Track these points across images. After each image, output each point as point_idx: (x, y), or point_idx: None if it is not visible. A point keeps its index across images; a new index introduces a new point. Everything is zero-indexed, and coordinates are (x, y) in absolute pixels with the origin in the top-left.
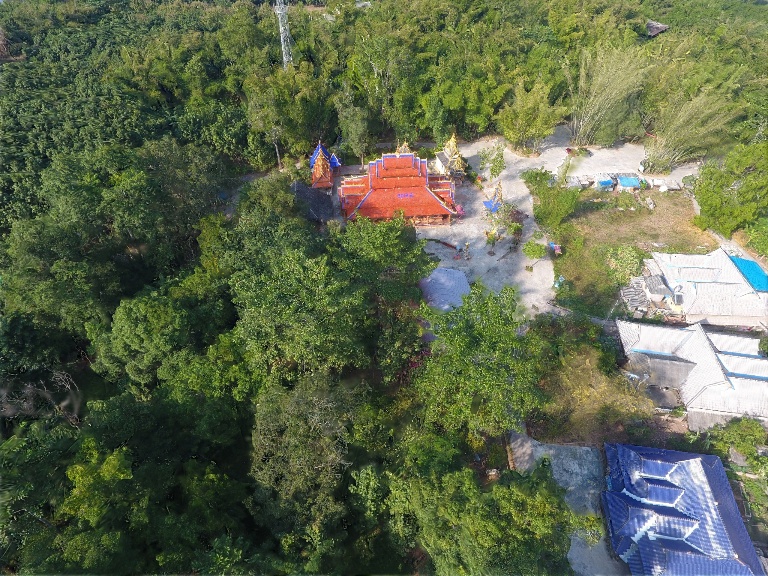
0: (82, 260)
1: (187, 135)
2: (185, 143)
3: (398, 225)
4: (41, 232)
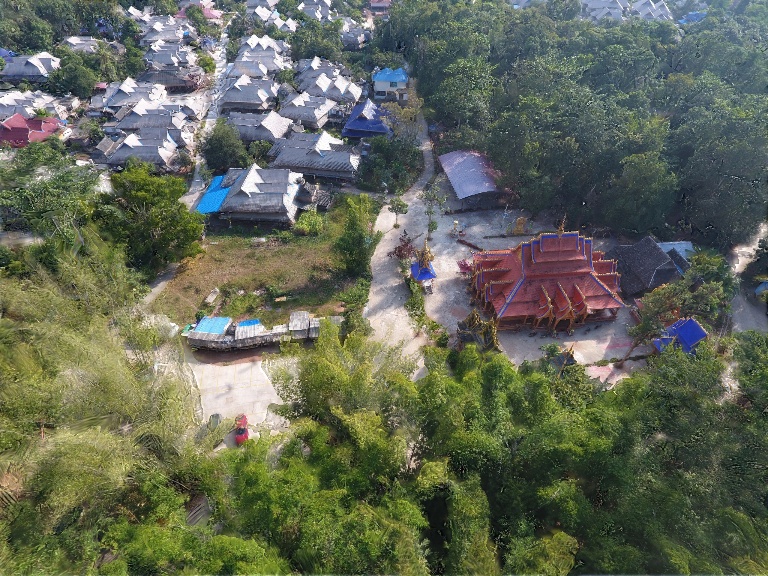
0: None
1: None
2: None
3: None
4: None
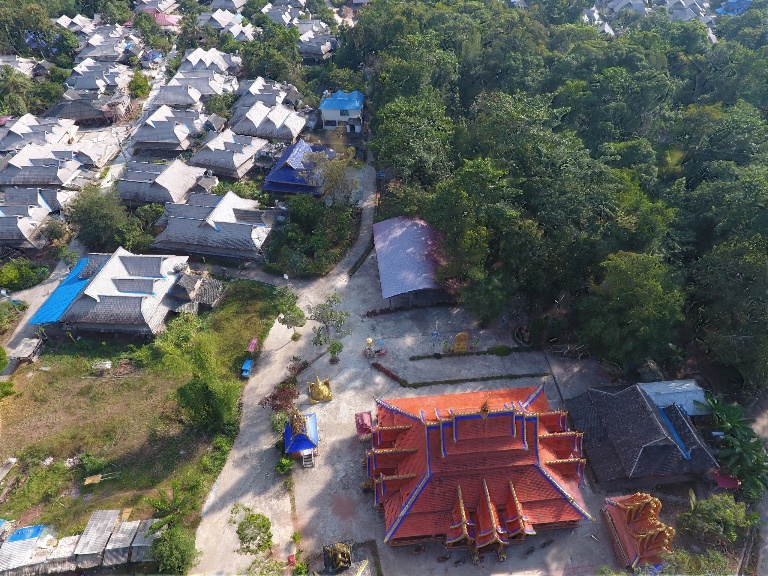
0: None
1: None
2: None
3: None
4: None
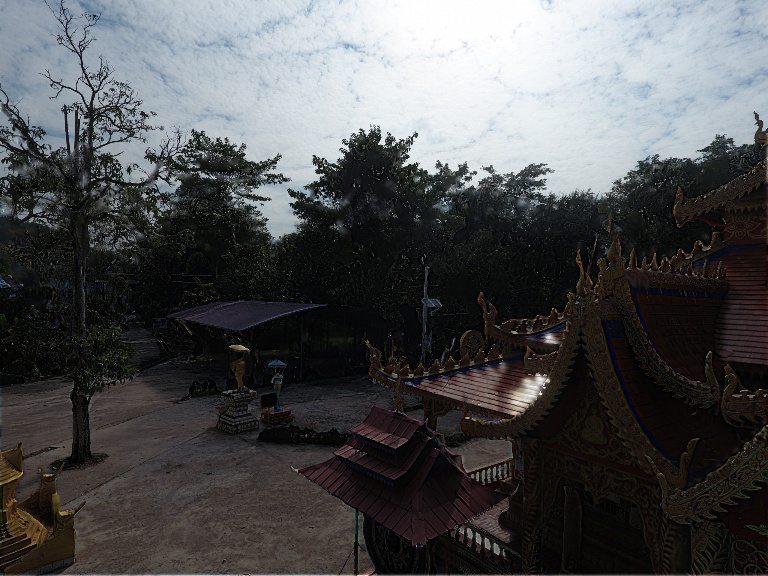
0: None
1: None
2: None
3: (356, 139)
4: None
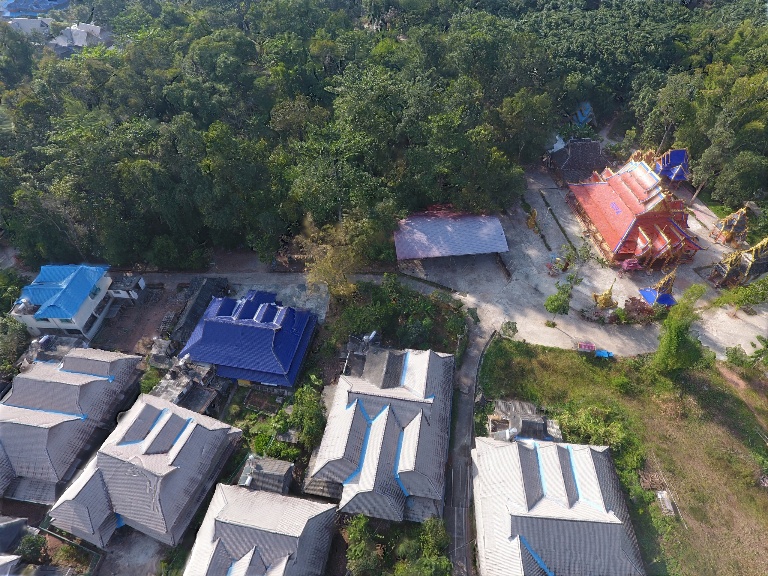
0: (434, 64)
1: (634, 83)
2: (629, 89)
3: None
4: (429, 35)
